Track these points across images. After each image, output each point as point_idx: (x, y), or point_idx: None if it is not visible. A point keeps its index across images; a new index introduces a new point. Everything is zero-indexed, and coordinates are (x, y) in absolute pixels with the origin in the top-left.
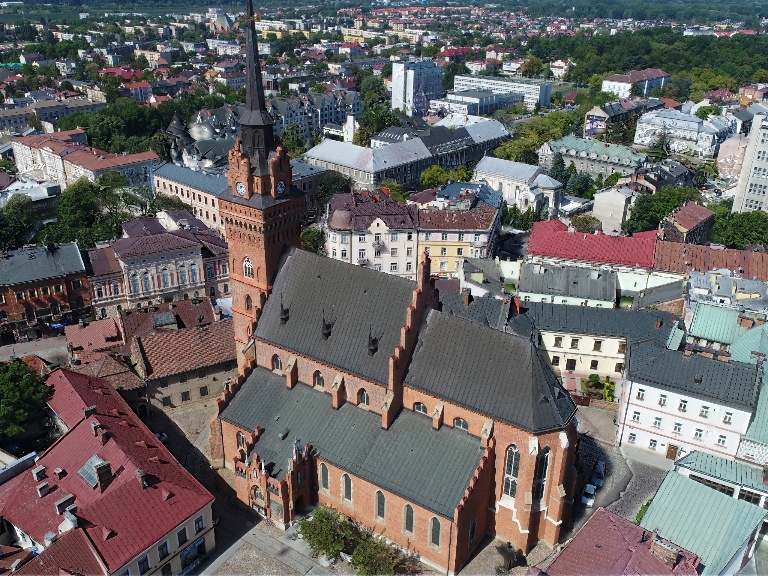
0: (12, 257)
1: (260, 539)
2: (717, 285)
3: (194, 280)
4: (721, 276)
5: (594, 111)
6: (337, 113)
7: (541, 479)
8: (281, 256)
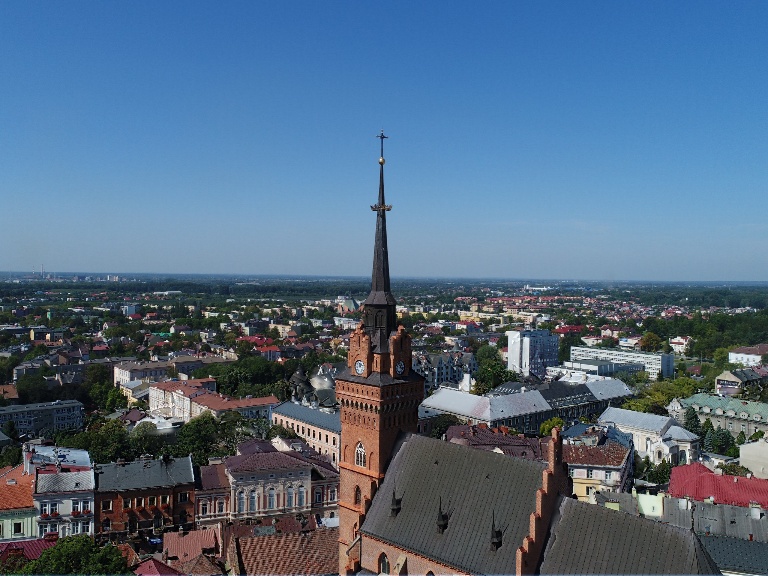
0: (128, 465)
1: None
2: None
3: (300, 504)
4: None
5: (724, 376)
6: (453, 372)
7: None
8: (396, 442)
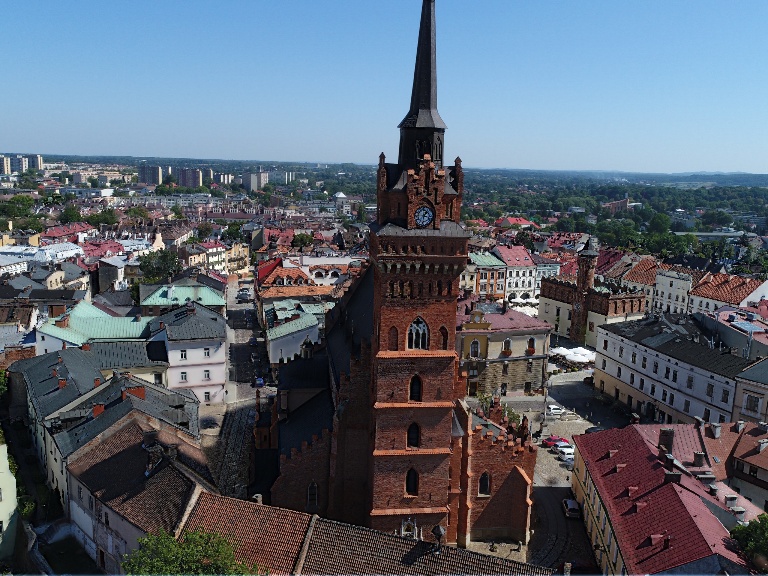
0: None
1: (534, 479)
2: None
3: None
4: None
5: None
6: None
7: None
8: None
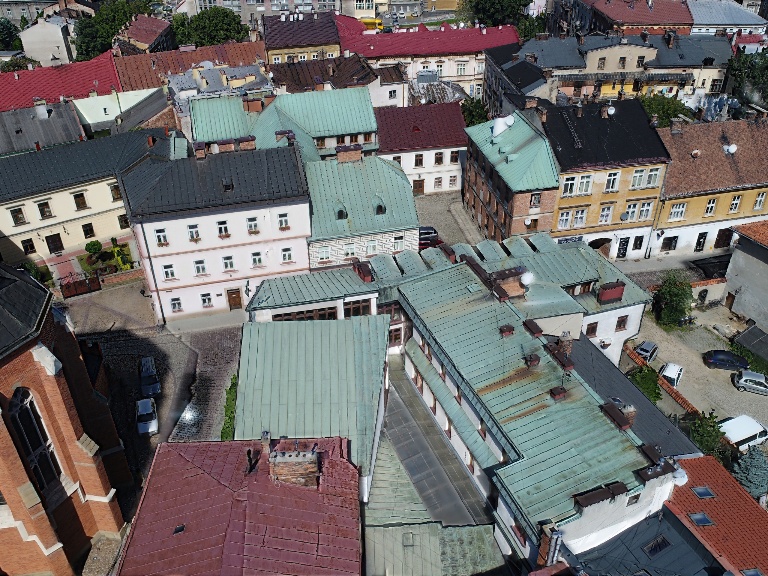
0: None
1: None
2: (204, 79)
3: None
4: (204, 70)
5: None
6: None
7: (41, 447)
8: None
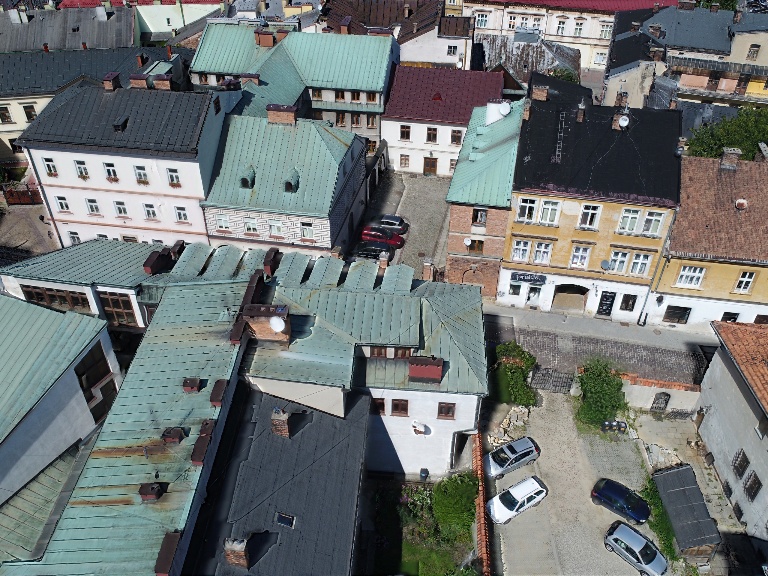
0: None
1: None
2: (262, 2)
3: None
4: None
5: None
6: None
7: None
8: None
